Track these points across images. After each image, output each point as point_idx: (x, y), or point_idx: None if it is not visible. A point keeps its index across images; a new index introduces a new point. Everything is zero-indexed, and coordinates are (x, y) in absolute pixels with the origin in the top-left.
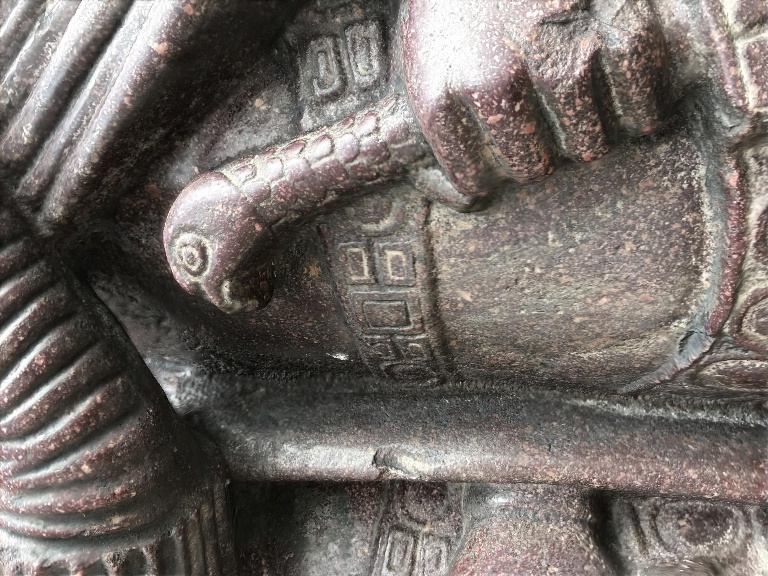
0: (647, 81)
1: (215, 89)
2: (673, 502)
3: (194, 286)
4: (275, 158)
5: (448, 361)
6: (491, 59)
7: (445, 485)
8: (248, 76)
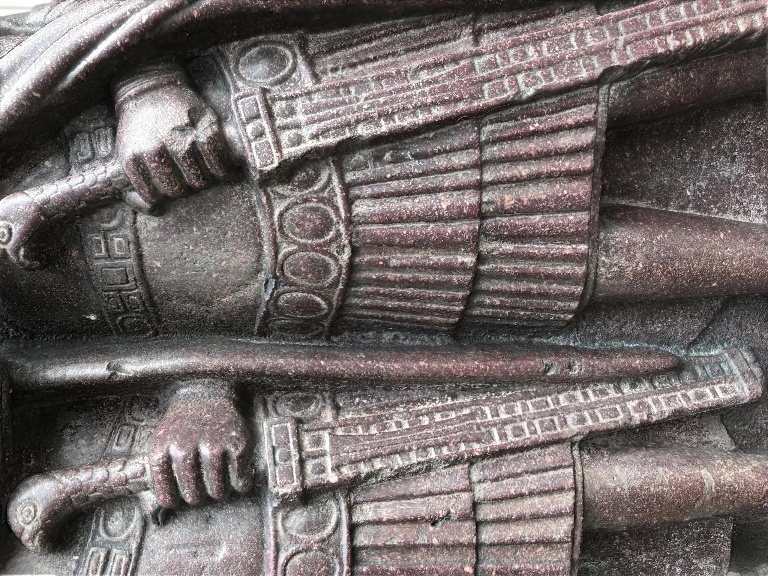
0: (217, 155)
1: (22, 154)
2: (286, 394)
3: (2, 250)
4: (54, 184)
5: (155, 313)
6: (151, 141)
7: (158, 401)
8: (42, 149)
